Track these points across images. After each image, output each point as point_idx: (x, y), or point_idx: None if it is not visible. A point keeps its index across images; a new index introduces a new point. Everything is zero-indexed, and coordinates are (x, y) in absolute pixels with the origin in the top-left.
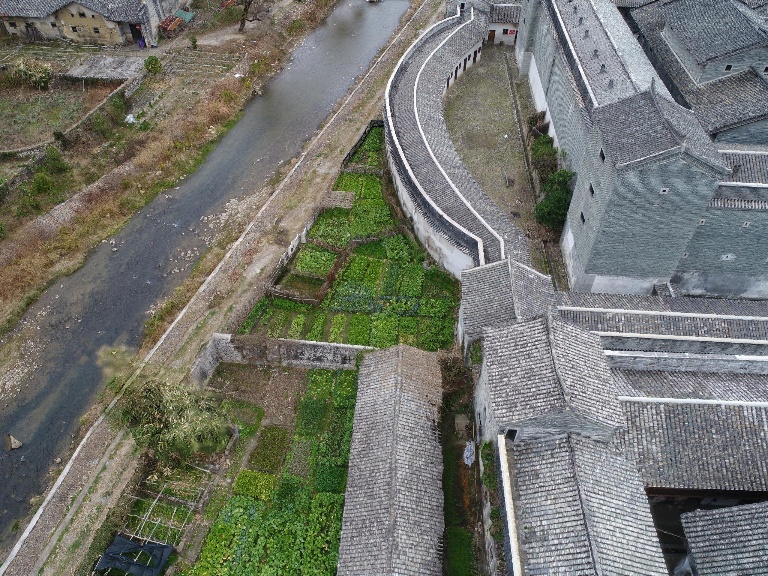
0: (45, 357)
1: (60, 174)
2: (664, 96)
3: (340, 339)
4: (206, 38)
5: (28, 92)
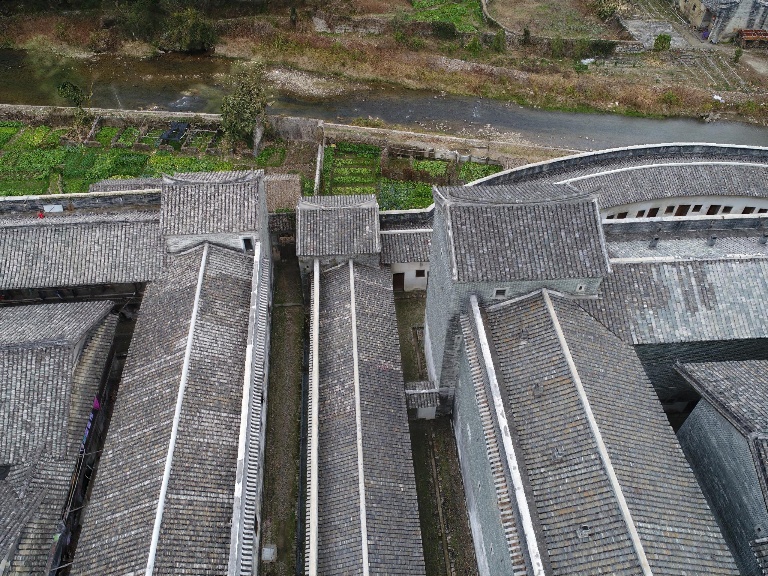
0: (332, 97)
1: (495, 52)
2: (599, 219)
3: (348, 192)
4: (767, 65)
5: (595, 18)
